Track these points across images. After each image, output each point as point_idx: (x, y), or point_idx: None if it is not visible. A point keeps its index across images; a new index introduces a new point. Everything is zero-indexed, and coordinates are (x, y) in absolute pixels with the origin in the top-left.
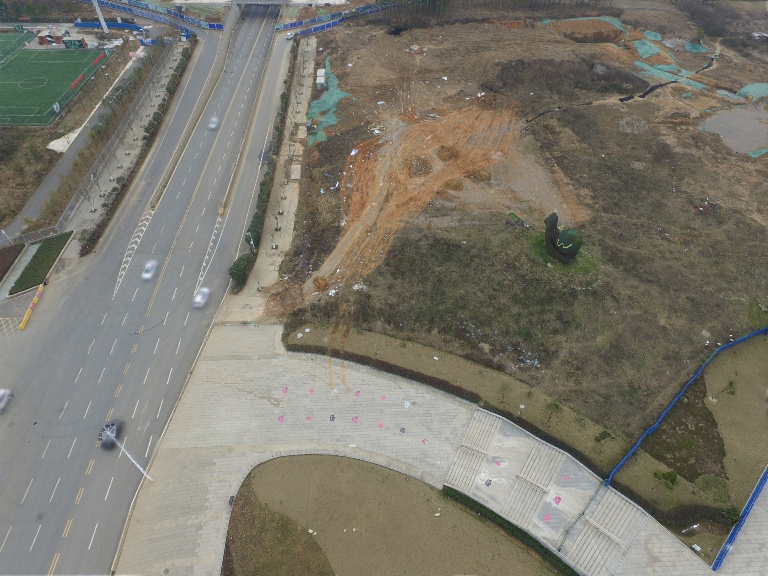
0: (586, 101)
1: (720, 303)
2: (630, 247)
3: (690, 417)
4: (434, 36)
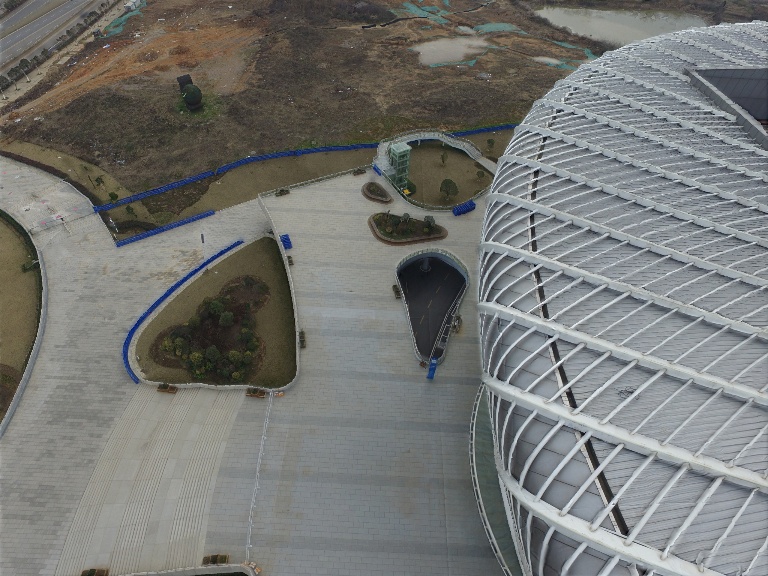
0: (332, 26)
1: (283, 138)
2: (254, 107)
3: (191, 189)
4: None
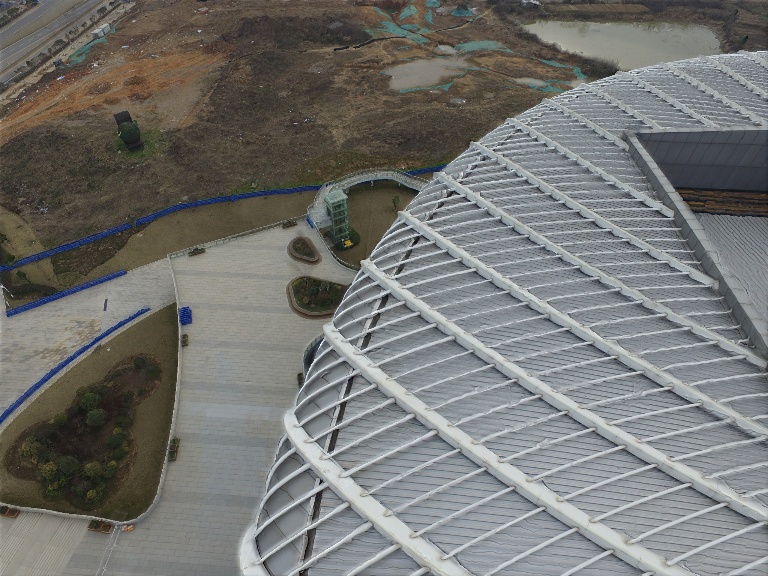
0: (302, 50)
1: (221, 181)
2: (198, 144)
3: (108, 243)
4: (232, 2)
